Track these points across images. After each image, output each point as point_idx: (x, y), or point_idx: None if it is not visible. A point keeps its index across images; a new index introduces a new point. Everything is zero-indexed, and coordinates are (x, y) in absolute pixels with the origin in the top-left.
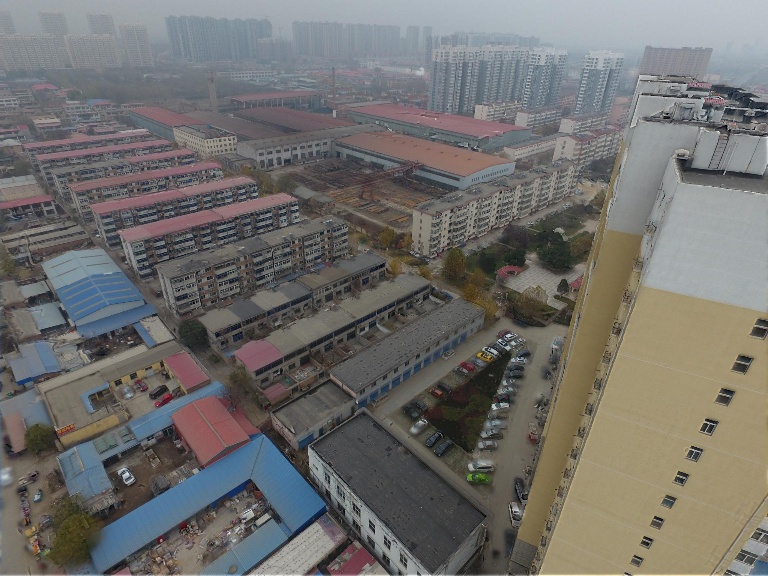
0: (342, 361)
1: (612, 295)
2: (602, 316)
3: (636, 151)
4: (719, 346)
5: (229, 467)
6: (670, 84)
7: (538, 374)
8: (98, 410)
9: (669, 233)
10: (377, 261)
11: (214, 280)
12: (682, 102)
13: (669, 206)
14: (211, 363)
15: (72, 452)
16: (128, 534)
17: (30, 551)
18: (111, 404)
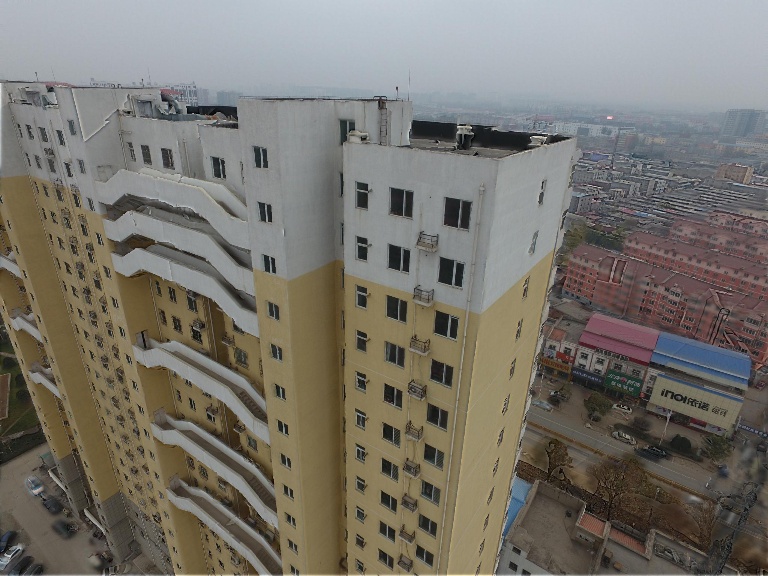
0: None
1: (316, 361)
2: (315, 394)
3: (285, 150)
4: (512, 327)
5: None
6: (20, 84)
7: (57, 541)
8: None
9: (494, 232)
10: None
11: None
12: (135, 94)
13: (494, 196)
14: None
15: None
16: None
17: None
18: None
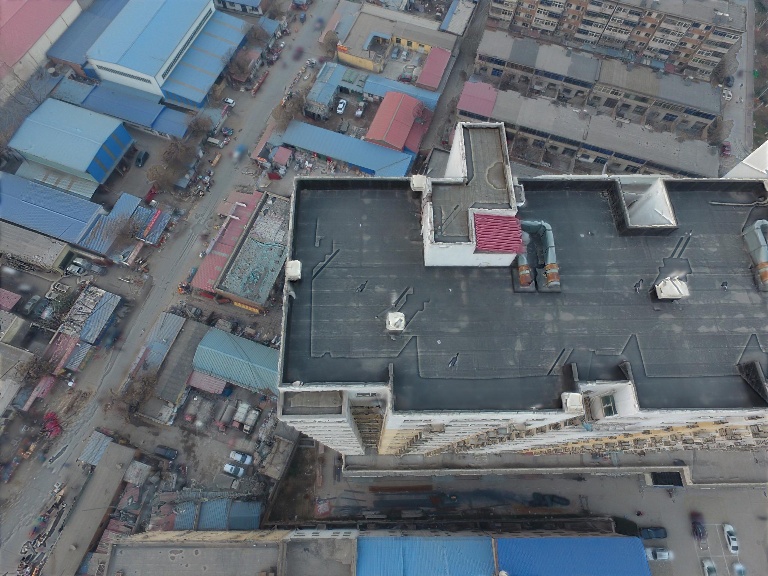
0: (530, 163)
1: None
2: None
3: (452, 151)
4: None
5: (375, 153)
6: None
7: None
8: (368, 50)
9: None
10: (708, 106)
11: (537, 2)
12: None
13: None
14: (460, 78)
15: (333, 66)
16: (305, 136)
17: (280, 102)
18: (381, 53)
